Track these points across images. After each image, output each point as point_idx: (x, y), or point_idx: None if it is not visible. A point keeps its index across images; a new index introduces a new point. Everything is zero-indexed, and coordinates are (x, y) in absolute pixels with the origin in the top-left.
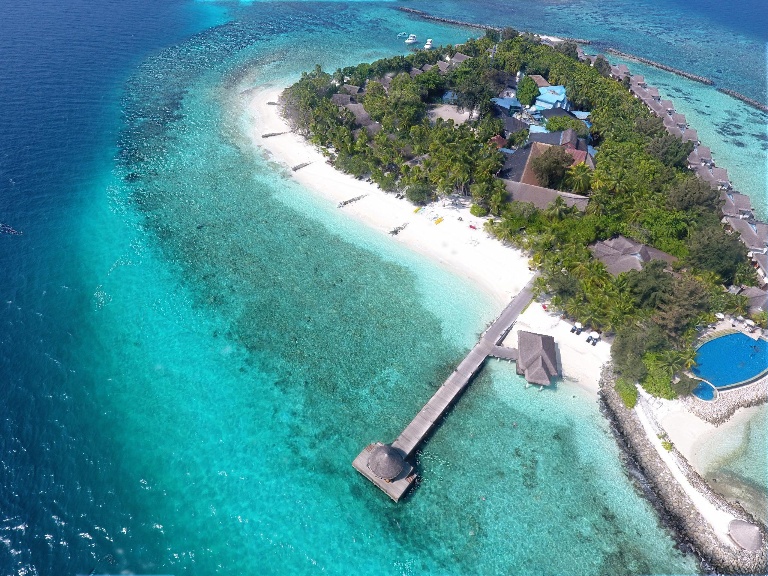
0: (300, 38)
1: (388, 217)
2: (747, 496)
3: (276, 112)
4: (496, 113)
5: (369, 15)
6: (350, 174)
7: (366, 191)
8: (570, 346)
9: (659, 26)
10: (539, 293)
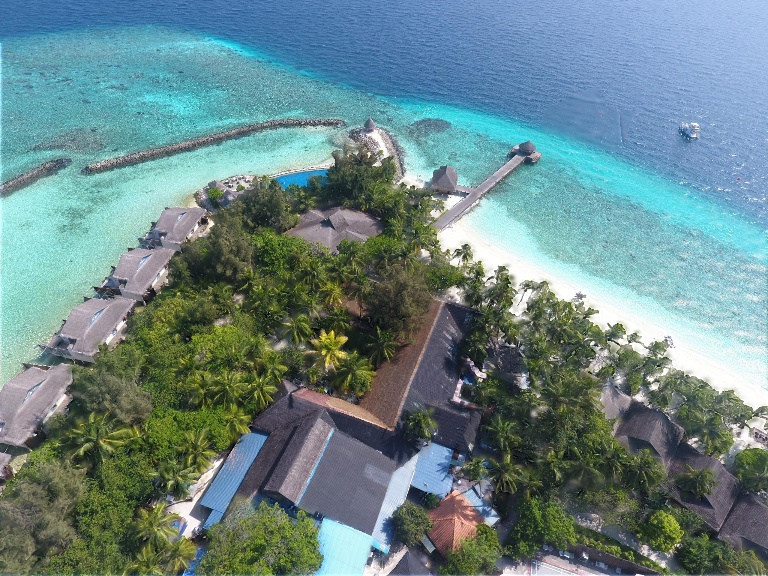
0: None
1: (598, 317)
2: (349, 144)
3: None
4: None
5: None
6: None
7: None
8: None
9: None
10: None
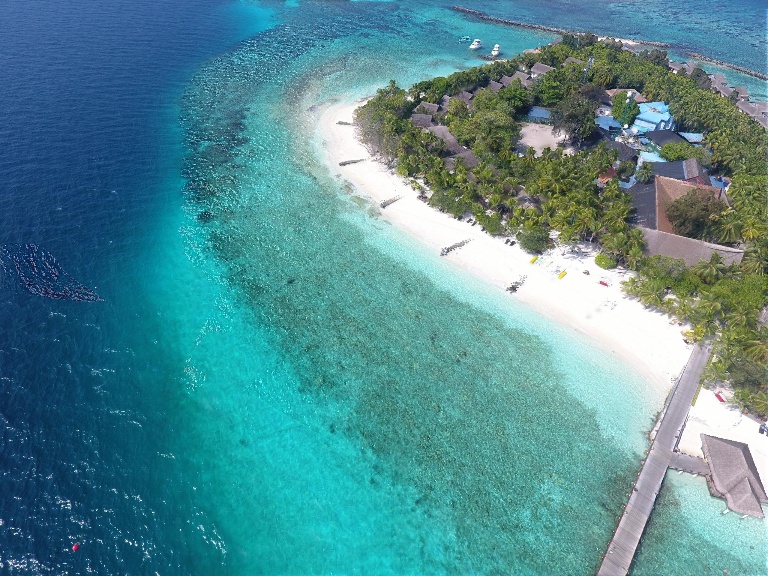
0: (356, 44)
1: (501, 269)
2: None
3: (354, 136)
4: (597, 136)
5: (423, 16)
6: (447, 213)
7: (469, 234)
8: (763, 453)
9: (737, 25)
10: (714, 381)
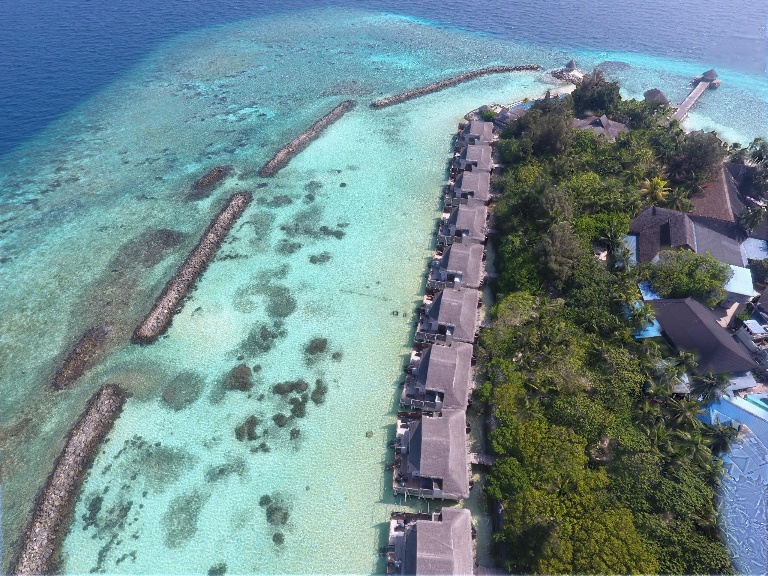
0: None
1: None
2: None
3: None
4: None
5: None
6: None
7: None
8: None
9: None
10: None
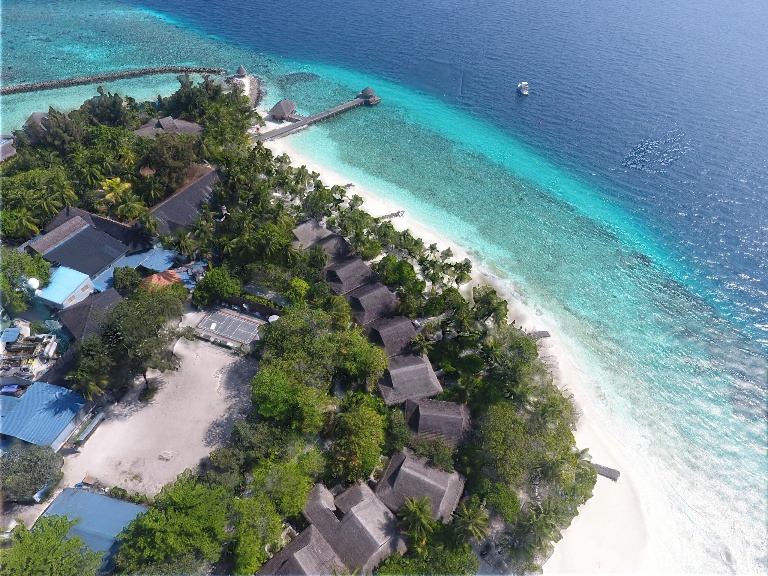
0: None
1: None
2: None
3: None
4: None
5: None
6: None
7: None
8: None
9: None
10: None
